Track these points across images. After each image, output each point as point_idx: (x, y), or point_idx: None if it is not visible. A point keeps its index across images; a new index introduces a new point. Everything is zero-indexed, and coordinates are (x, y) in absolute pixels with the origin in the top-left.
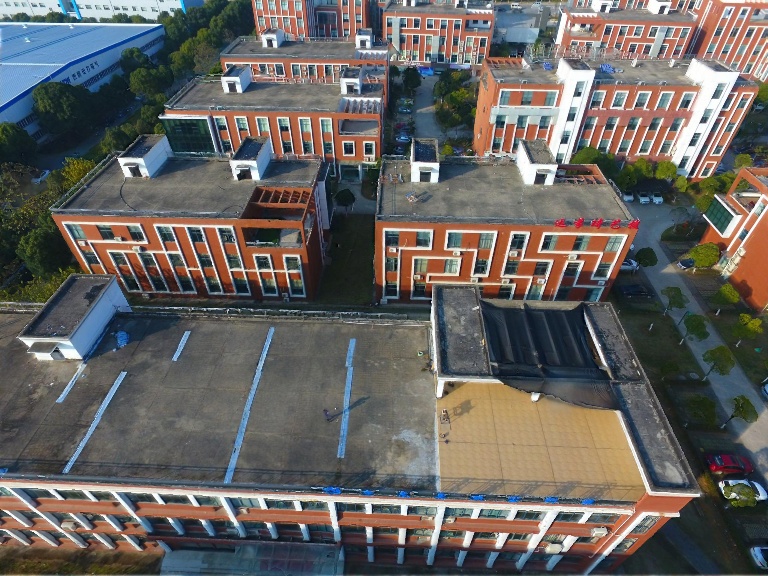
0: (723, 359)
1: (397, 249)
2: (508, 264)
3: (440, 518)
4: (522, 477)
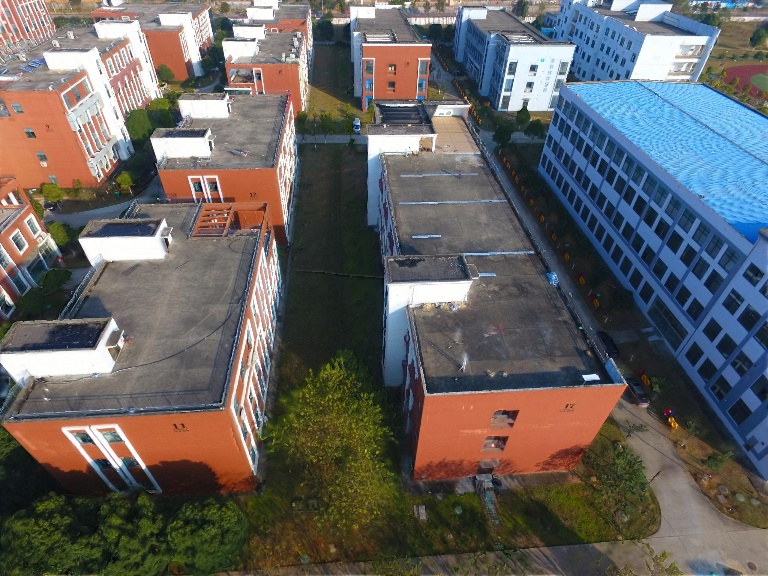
0: None
1: None
2: None
3: None
4: None
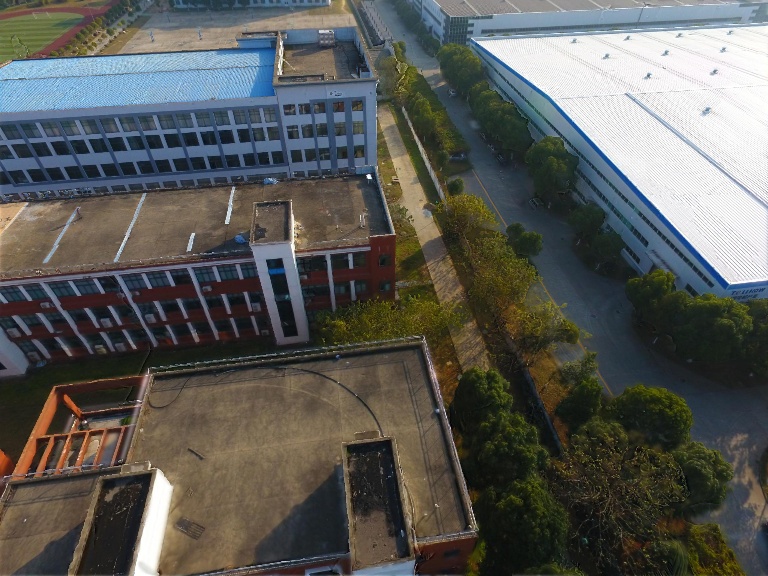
0: None
1: None
2: None
3: None
4: None
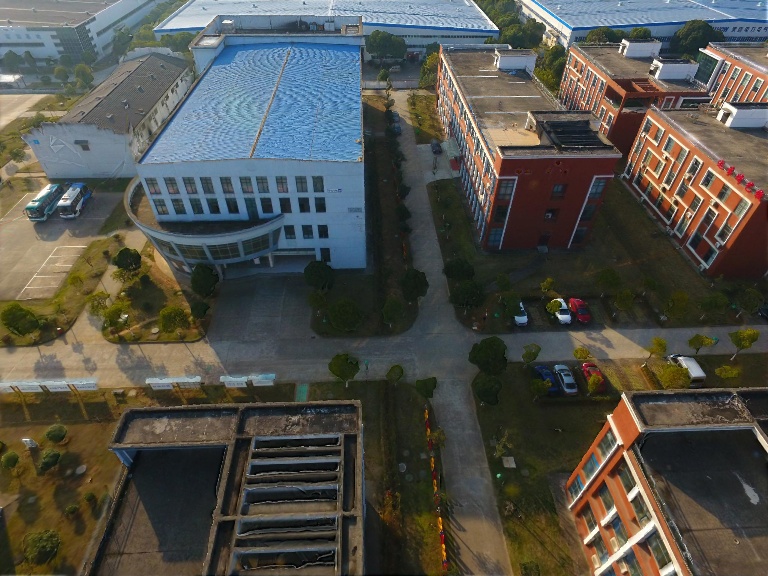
0: (673, 297)
1: (645, 136)
2: (683, 186)
3: None
4: (496, 144)
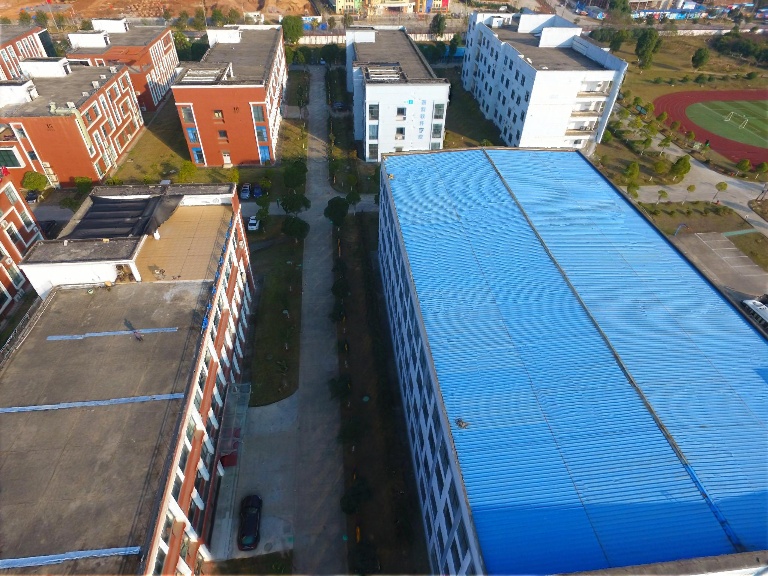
0: None
1: None
2: None
3: (226, 297)
4: (211, 248)
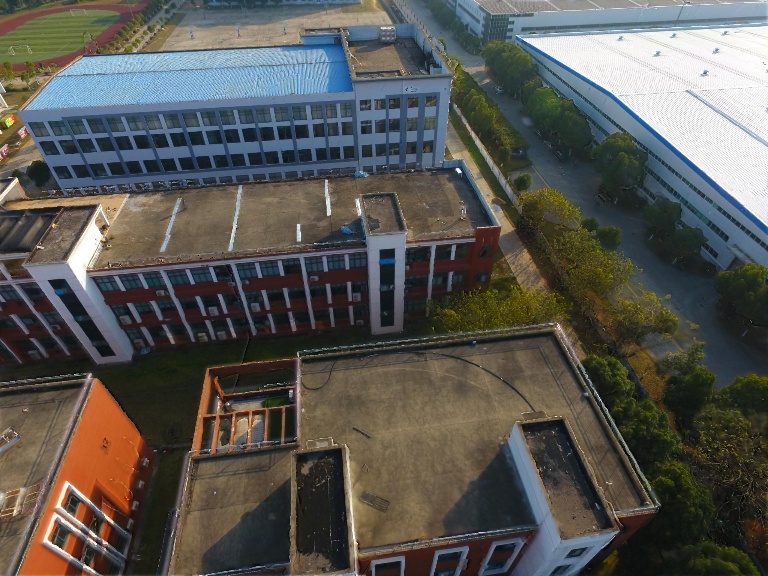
0: None
1: None
2: None
3: None
4: None
